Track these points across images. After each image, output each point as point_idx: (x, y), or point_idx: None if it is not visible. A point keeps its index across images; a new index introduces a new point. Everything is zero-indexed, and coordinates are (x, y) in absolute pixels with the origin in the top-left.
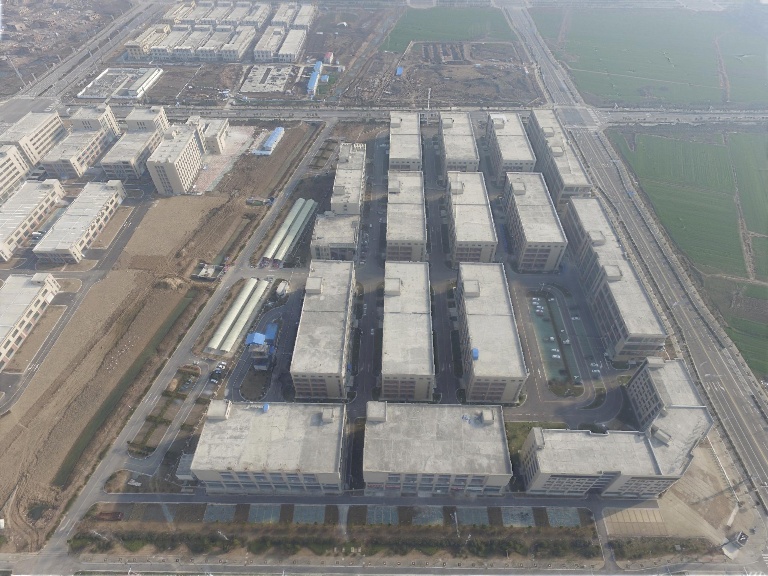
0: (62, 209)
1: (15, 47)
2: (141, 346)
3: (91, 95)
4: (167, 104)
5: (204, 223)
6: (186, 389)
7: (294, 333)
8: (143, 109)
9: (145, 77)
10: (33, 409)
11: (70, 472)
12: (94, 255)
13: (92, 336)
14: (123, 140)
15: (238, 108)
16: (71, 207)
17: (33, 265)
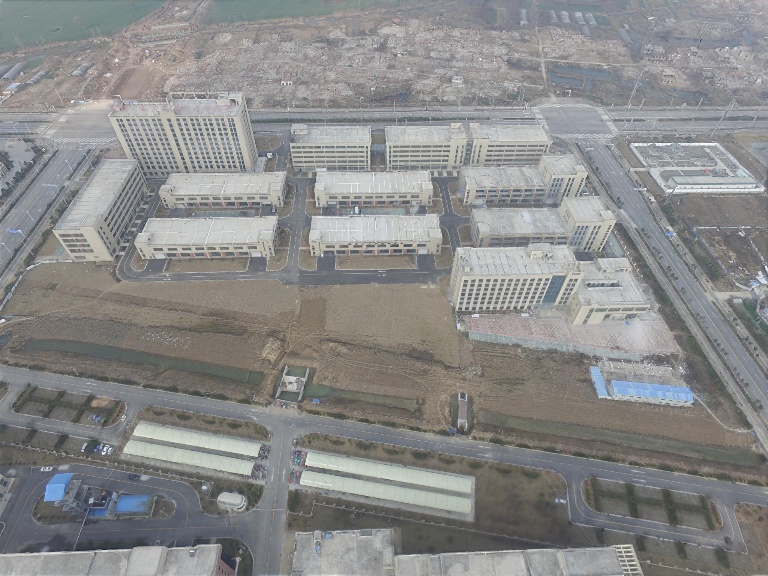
0: (403, 212)
1: (702, 70)
2: (175, 353)
3: (641, 153)
4: (672, 224)
5: (395, 351)
6: (86, 418)
7: (138, 541)
8: (602, 204)
9: (720, 180)
10: (117, 296)
11: (35, 349)
12: (323, 263)
13: (200, 305)
14: (532, 212)
15: (725, 311)
16: (389, 217)
17: (310, 225)
